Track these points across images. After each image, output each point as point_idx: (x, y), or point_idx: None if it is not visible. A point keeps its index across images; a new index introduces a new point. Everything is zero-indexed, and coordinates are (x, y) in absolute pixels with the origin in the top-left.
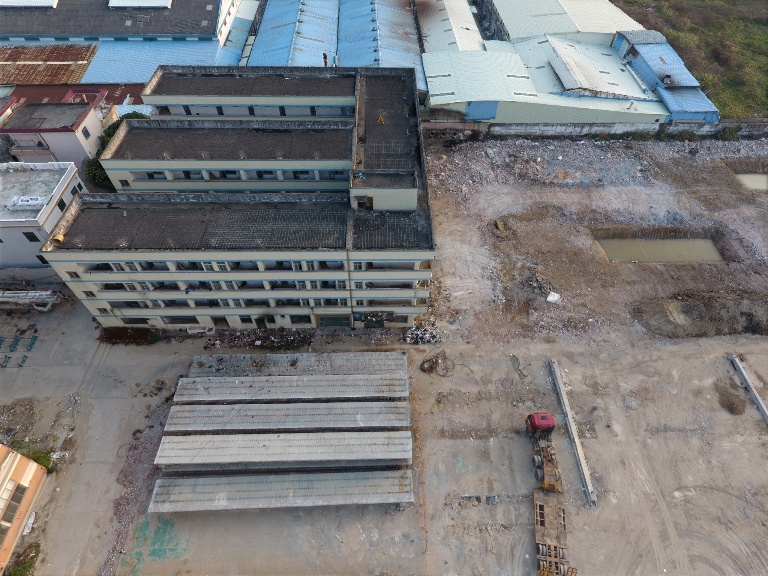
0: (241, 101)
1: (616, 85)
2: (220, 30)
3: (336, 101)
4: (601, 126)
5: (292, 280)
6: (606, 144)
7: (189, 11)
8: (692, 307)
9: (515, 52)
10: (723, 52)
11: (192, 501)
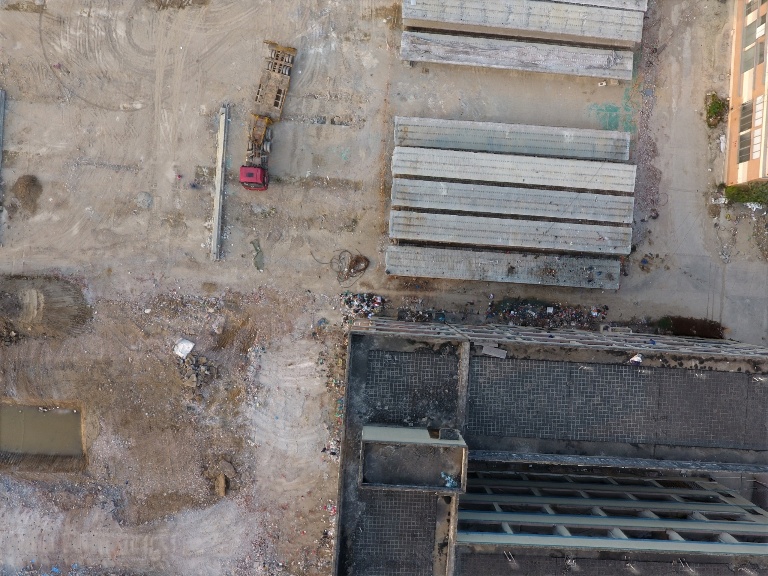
0: None
1: None
2: None
3: None
4: None
5: None
6: None
7: None
8: (5, 310)
9: None
10: None
11: (594, 137)
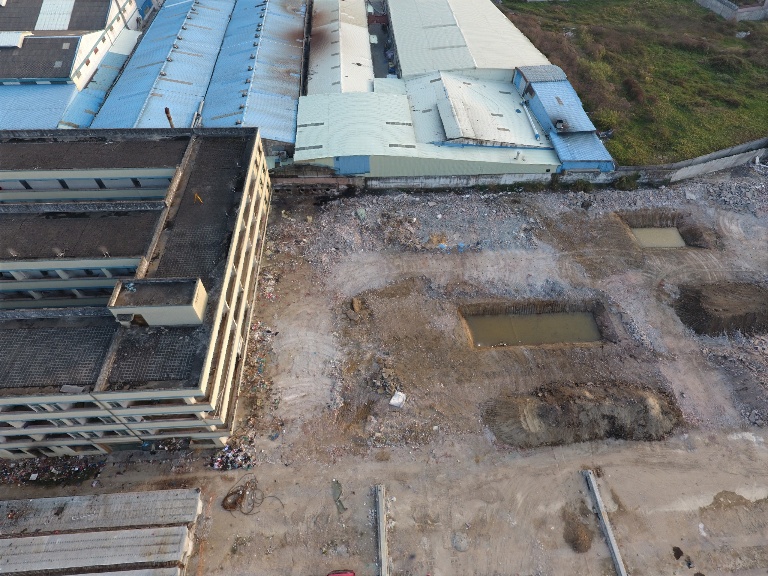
0: (42, 175)
1: (506, 131)
2: (78, 71)
3: (155, 173)
4: (488, 177)
5: (42, 419)
6: (494, 197)
7: (42, 50)
8: (548, 410)
9: (405, 92)
10: (635, 84)
11: None
